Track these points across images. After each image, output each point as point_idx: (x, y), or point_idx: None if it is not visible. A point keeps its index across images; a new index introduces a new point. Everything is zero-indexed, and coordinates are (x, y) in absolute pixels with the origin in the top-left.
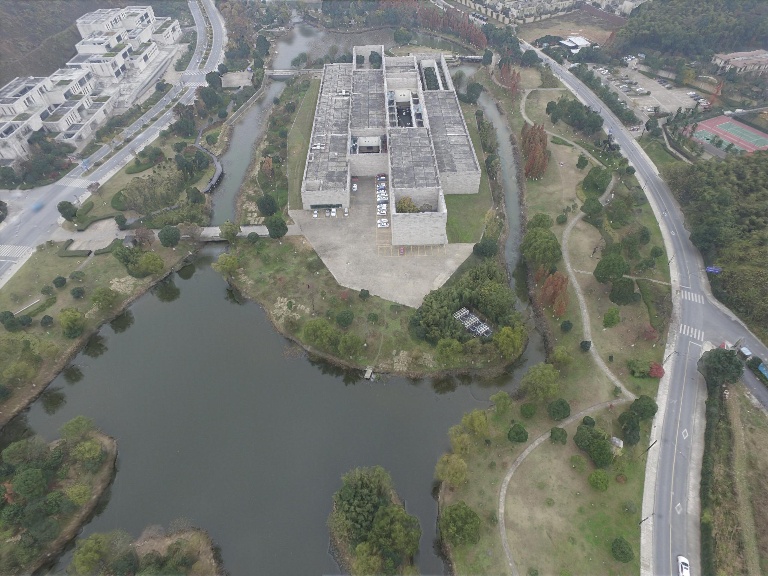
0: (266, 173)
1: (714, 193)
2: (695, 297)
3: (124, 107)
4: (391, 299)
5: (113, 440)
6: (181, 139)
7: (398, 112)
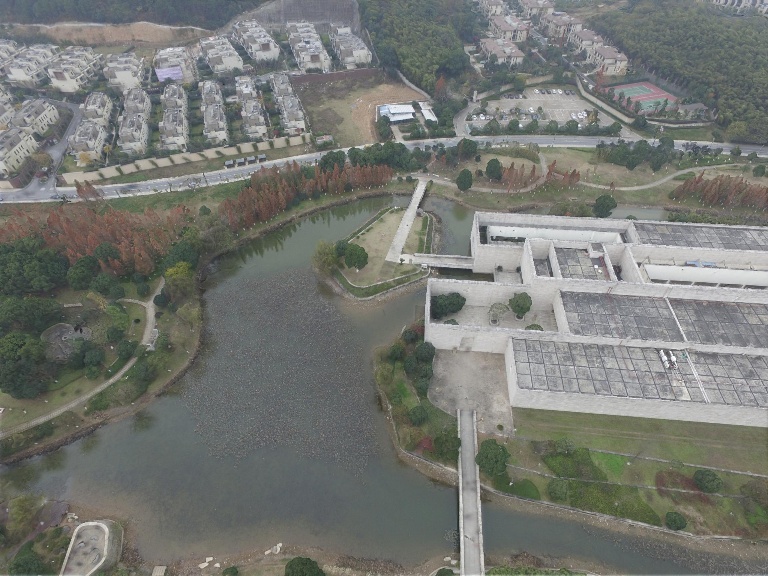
0: None
1: None
2: None
3: None
4: None
5: None
6: None
7: None
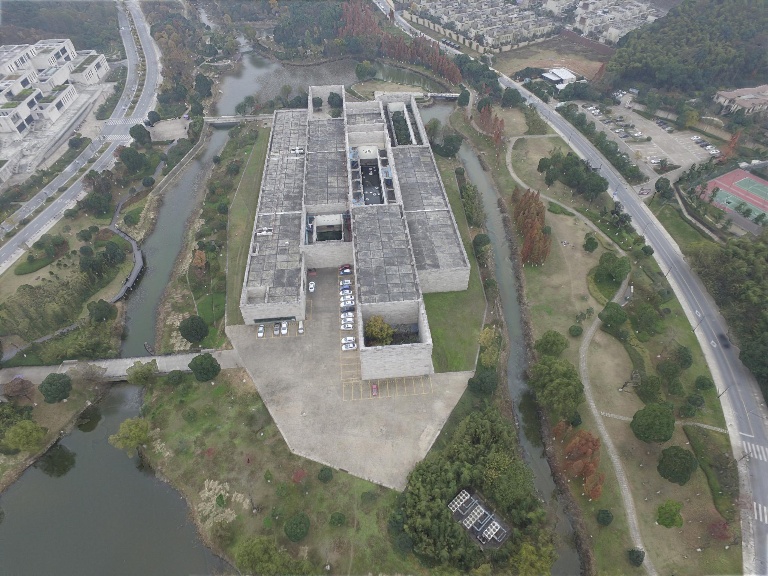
0: (196, 274)
1: (761, 292)
2: (762, 453)
3: (26, 172)
4: (363, 475)
5: None
6: (93, 219)
7: (364, 171)
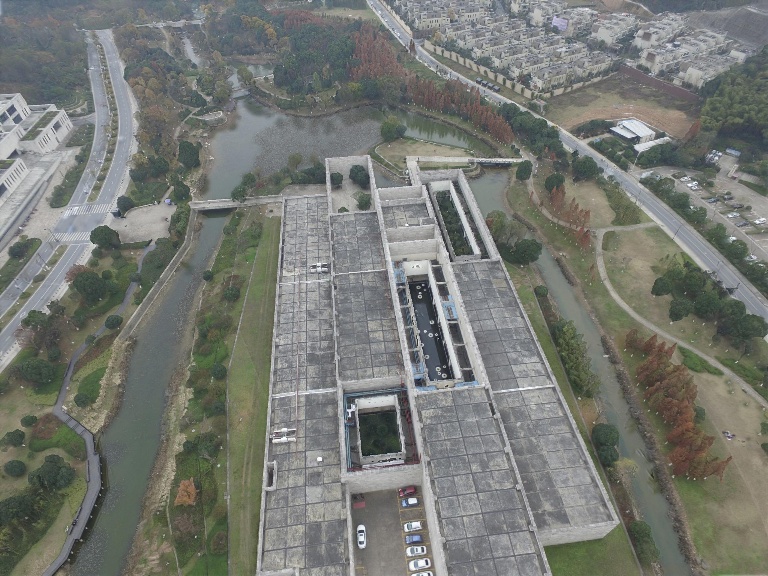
0: (181, 529)
1: None
2: None
3: None
4: None
5: None
6: (30, 396)
7: None
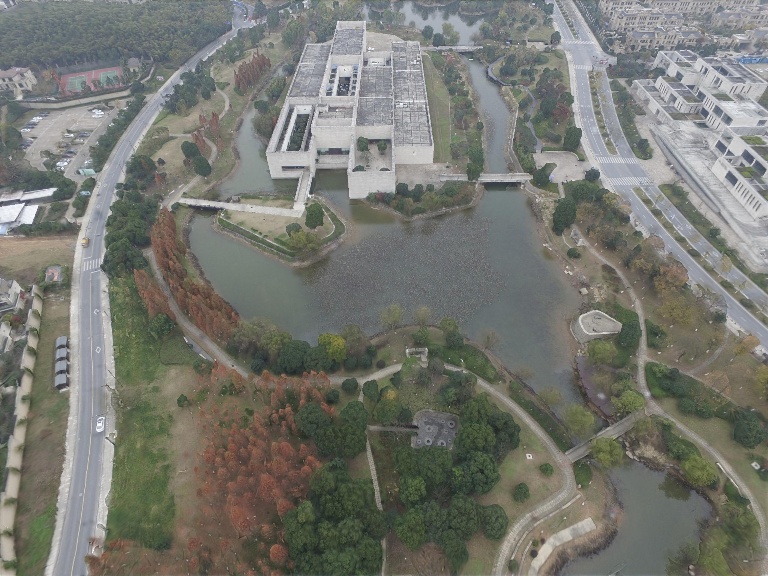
0: None
1: None
2: None
3: None
4: None
5: (463, 14)
6: None
7: None
